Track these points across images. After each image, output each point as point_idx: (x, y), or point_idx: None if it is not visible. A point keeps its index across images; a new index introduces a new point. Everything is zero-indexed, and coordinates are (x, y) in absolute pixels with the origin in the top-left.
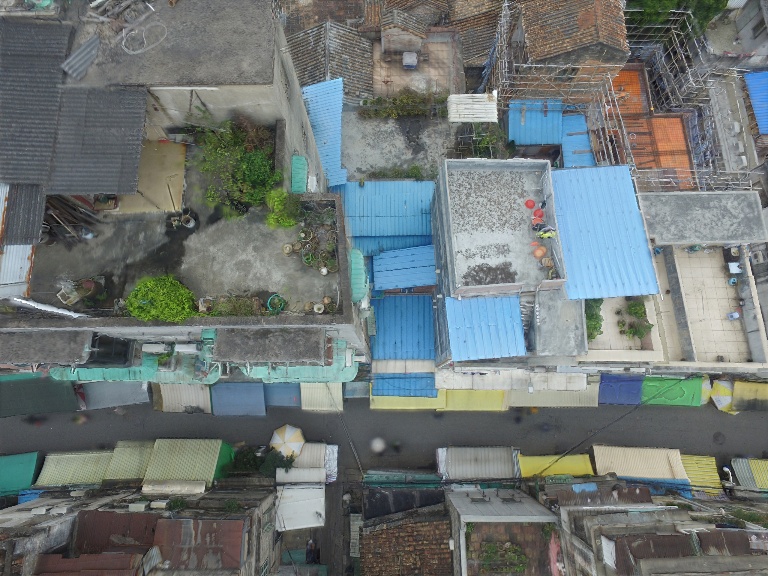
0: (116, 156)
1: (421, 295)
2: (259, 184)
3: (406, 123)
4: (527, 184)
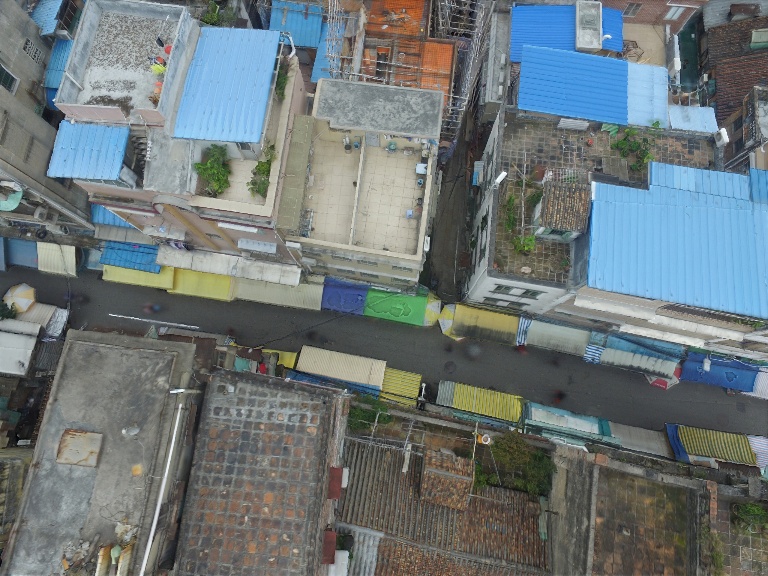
0: None
1: None
2: None
3: (156, 1)
4: (174, 33)
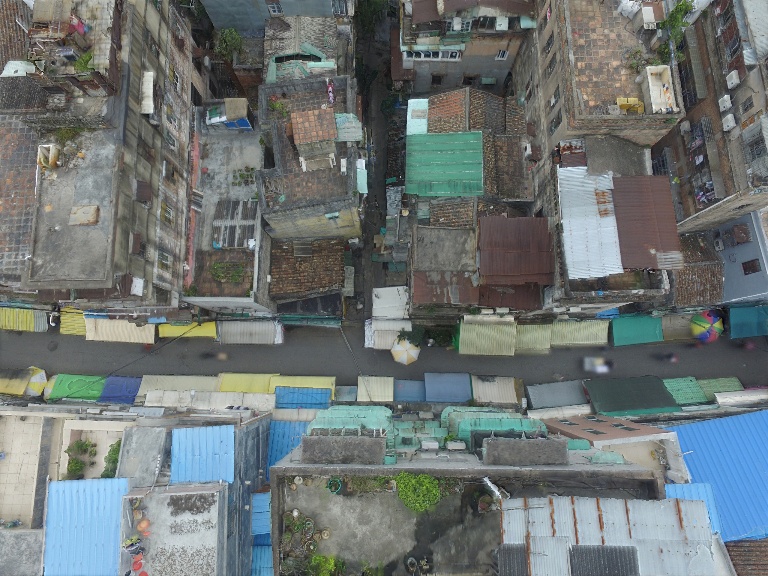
0: None
1: None
2: None
3: None
4: None
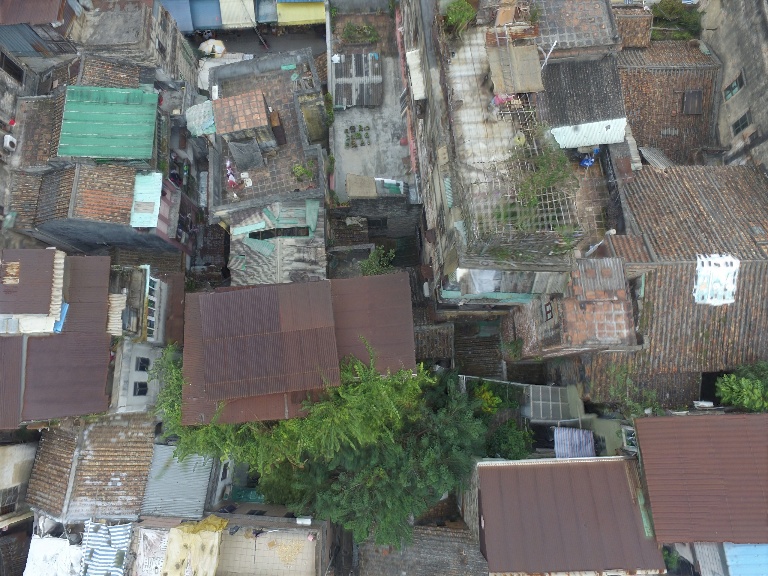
0: None
1: None
2: None
3: None
4: None
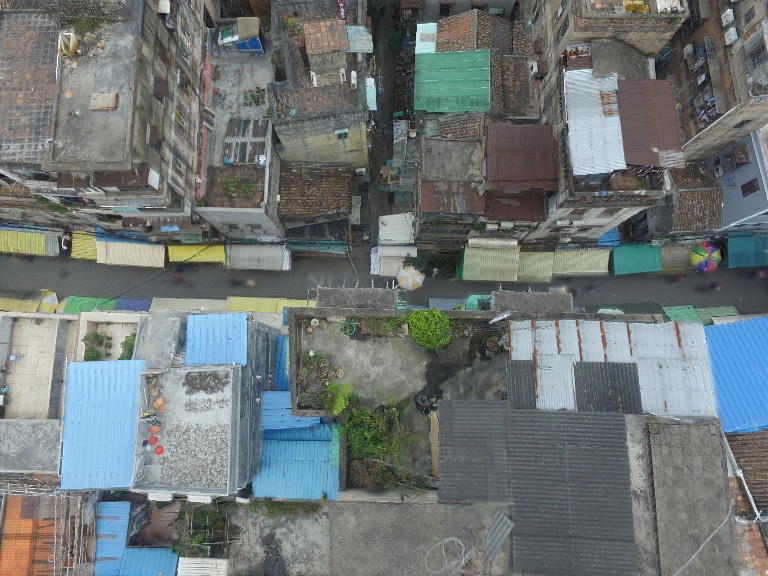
0: (457, 435)
1: (284, 390)
2: (358, 425)
3: (278, 572)
4: (158, 471)
